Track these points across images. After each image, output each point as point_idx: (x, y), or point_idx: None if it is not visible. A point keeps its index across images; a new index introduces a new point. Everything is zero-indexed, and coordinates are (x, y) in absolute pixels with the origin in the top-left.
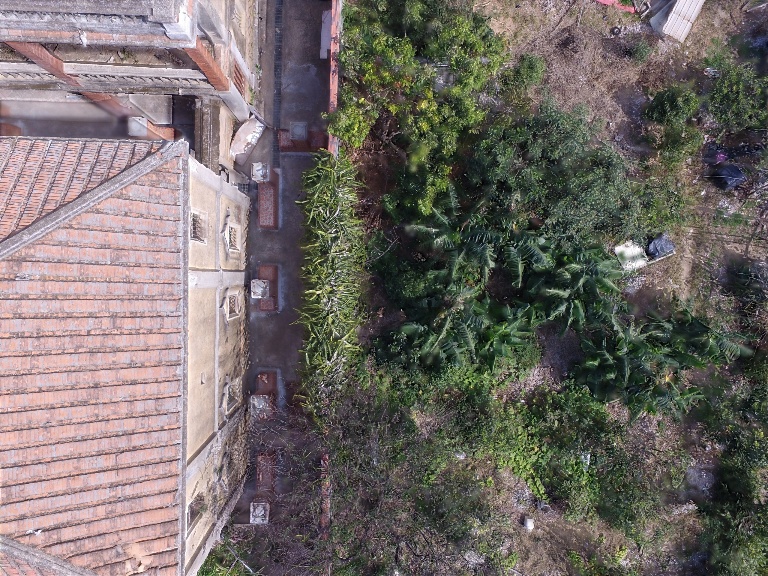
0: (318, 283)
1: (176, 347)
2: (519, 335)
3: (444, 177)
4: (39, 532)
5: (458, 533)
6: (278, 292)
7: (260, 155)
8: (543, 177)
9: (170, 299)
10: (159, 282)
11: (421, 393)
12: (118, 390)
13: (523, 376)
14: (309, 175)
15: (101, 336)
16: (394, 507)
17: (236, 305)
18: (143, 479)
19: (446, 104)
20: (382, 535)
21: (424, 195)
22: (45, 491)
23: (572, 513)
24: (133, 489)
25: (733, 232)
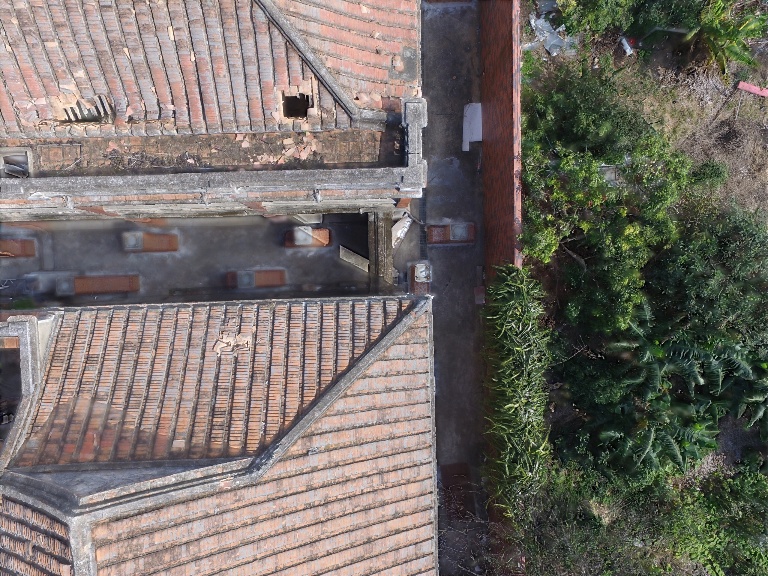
0: (514, 396)
1: (428, 491)
2: (707, 434)
3: (637, 290)
4: None
5: None
6: None
7: (408, 248)
8: (743, 291)
9: (423, 447)
10: (414, 433)
11: (598, 486)
12: (387, 542)
13: (698, 465)
14: (499, 291)
15: (372, 493)
16: None
17: None
18: None
19: (647, 226)
20: None
21: (626, 313)
22: None
23: None
24: None
25: None
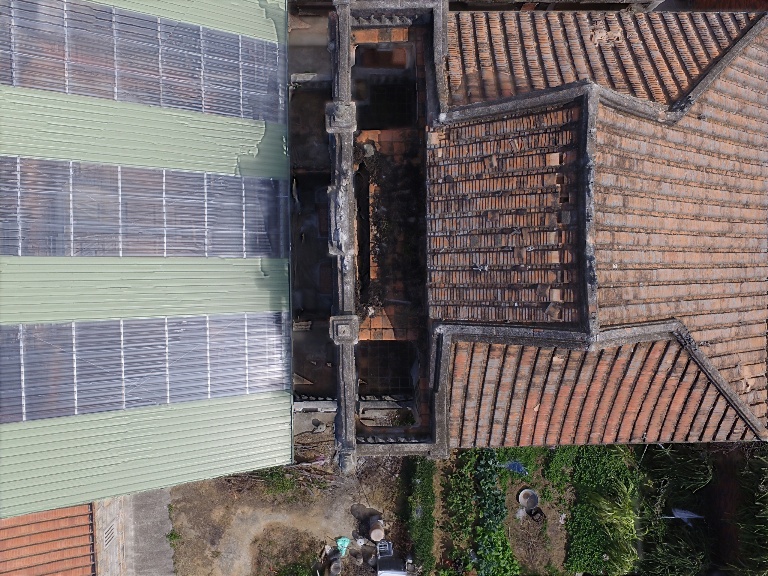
0: None
1: (764, 194)
2: None
3: None
4: None
5: None
6: None
7: None
8: None
9: (763, 150)
10: None
11: None
12: (741, 226)
13: None
14: None
15: (733, 177)
16: None
17: None
18: (750, 309)
19: None
20: None
21: None
22: (711, 308)
23: None
24: (748, 316)
25: None
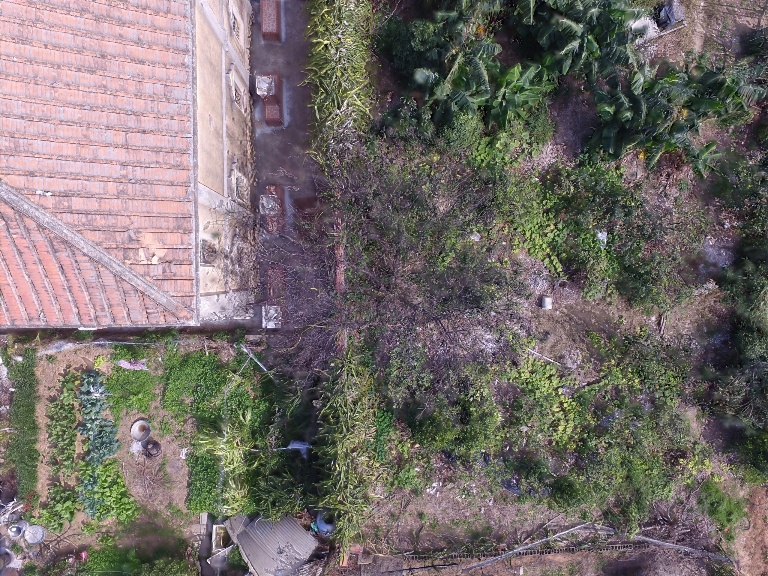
0: (325, 34)
1: (184, 37)
2: (532, 90)
3: None
4: (49, 194)
5: (476, 294)
6: (283, 108)
7: None
8: None
9: None
10: None
11: (433, 174)
12: (126, 66)
13: (536, 153)
14: None
15: (107, 5)
16: (409, 292)
17: (241, 104)
18: (154, 166)
19: None
20: (398, 322)
21: None
22: (54, 152)
23: (591, 286)
24: (144, 173)
25: (744, 5)
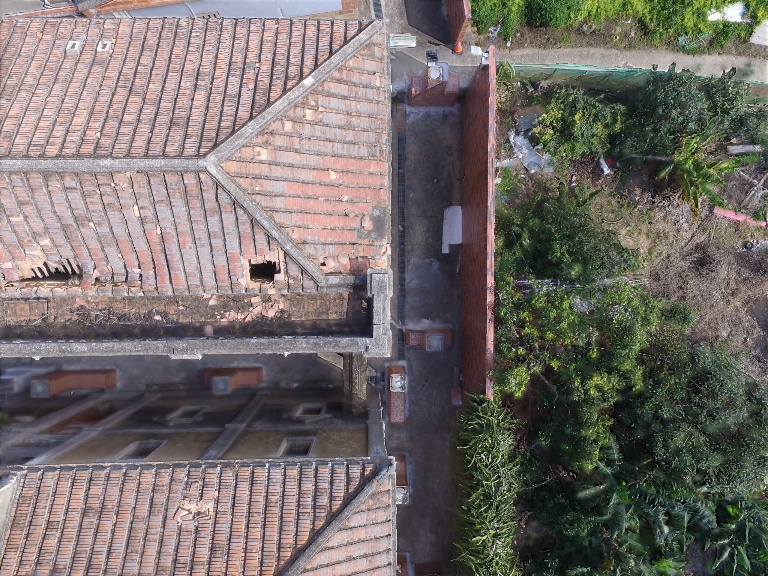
0: (482, 528)
1: None
2: (674, 565)
3: (606, 428)
4: None
5: None
6: None
7: None
8: (709, 437)
9: None
10: None
11: None
12: None
13: None
14: (470, 422)
15: None
16: None
17: None
18: None
19: (615, 372)
20: None
21: (593, 456)
22: None
23: None
24: None
25: None
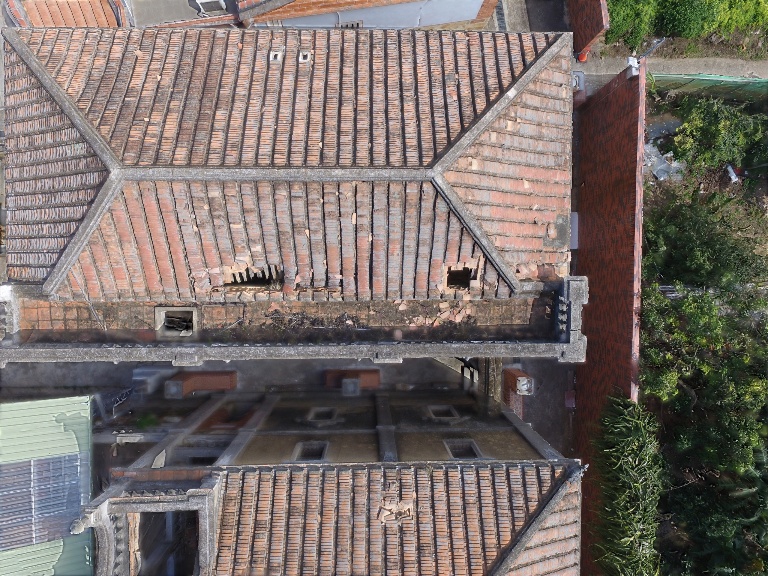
0: (629, 529)
1: None
2: None
3: (755, 432)
4: None
5: None
6: None
7: None
8: None
9: None
10: None
11: None
12: None
13: None
14: (616, 425)
15: None
16: None
17: None
18: None
19: None
20: None
21: (748, 459)
22: None
23: None
24: None
25: None
